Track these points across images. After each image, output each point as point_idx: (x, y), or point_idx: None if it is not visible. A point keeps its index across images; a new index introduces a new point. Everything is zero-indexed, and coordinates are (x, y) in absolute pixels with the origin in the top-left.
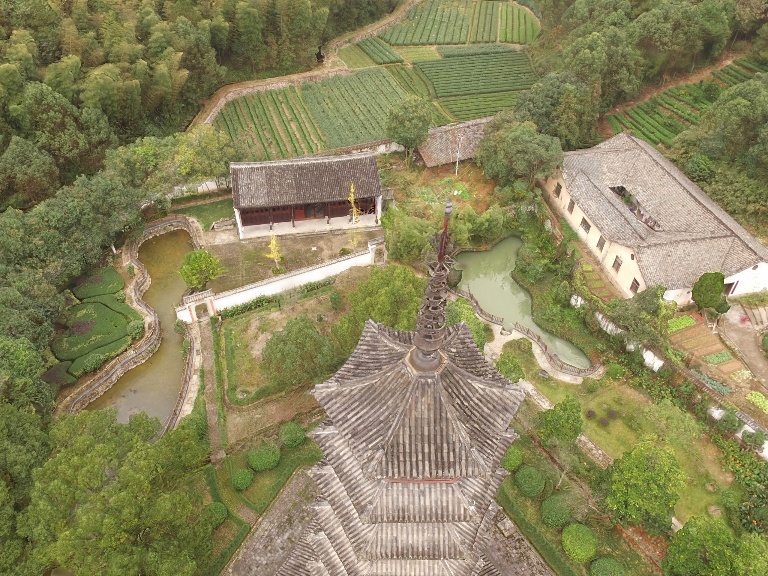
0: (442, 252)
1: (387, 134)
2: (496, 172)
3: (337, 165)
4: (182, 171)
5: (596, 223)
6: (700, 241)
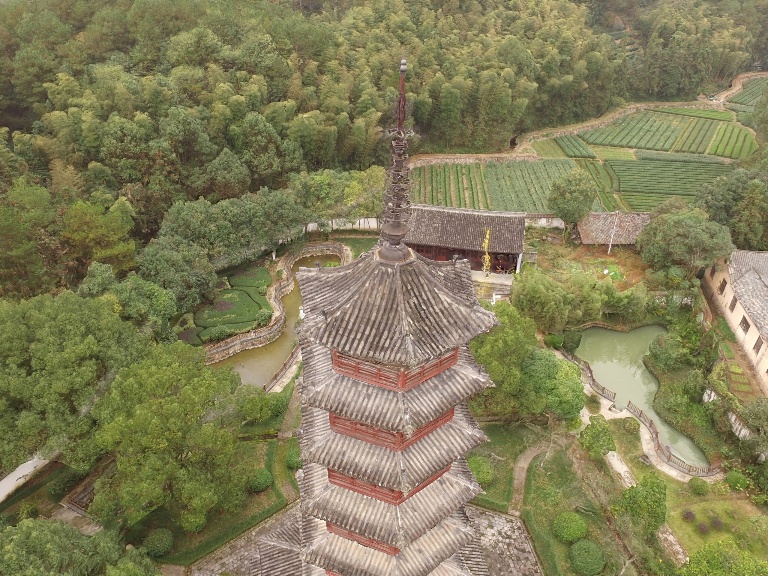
0: (401, 118)
1: (547, 205)
2: (652, 255)
3: (485, 219)
4: (348, 202)
5: (755, 321)
6: None
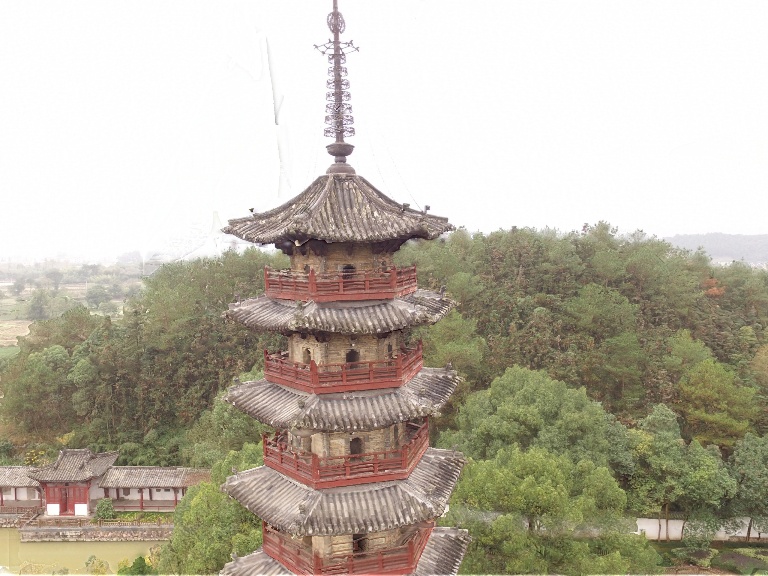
0: None
1: None
2: None
3: None
4: None
5: None
6: None
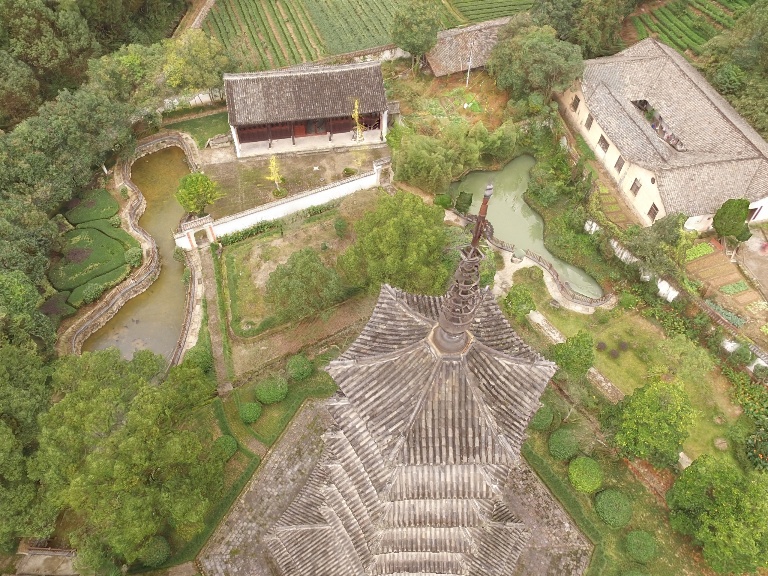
0: (477, 236)
1: (392, 39)
2: (510, 83)
3: (339, 76)
4: (172, 83)
5: (615, 142)
6: (726, 163)
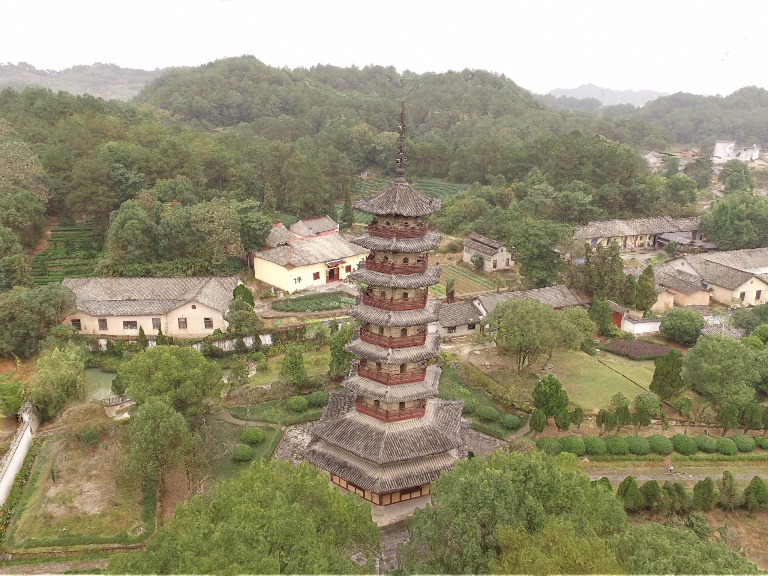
0: None
1: None
2: (24, 335)
3: None
4: None
5: (143, 313)
6: (207, 285)
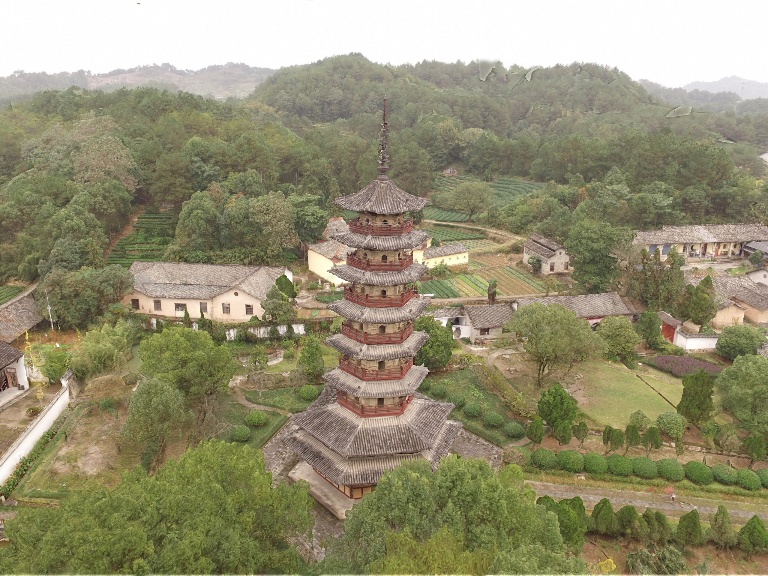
0: None
1: None
2: (86, 310)
3: None
4: None
5: (192, 297)
6: (254, 274)
